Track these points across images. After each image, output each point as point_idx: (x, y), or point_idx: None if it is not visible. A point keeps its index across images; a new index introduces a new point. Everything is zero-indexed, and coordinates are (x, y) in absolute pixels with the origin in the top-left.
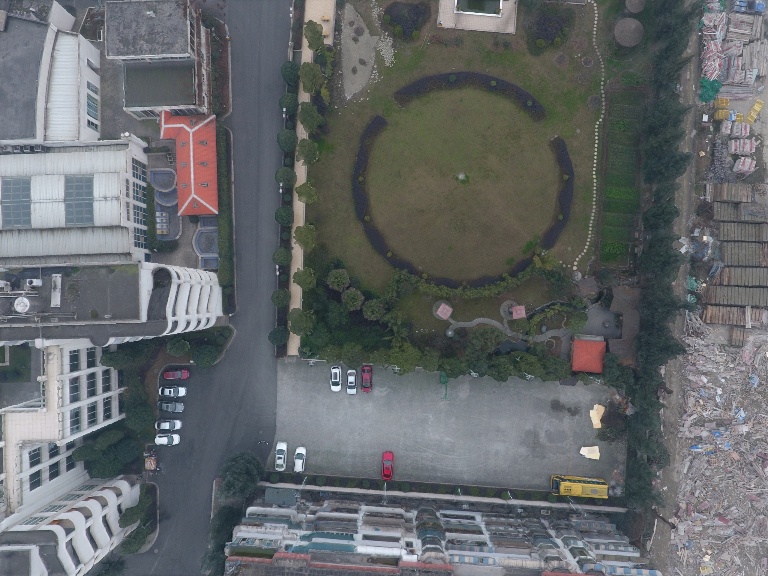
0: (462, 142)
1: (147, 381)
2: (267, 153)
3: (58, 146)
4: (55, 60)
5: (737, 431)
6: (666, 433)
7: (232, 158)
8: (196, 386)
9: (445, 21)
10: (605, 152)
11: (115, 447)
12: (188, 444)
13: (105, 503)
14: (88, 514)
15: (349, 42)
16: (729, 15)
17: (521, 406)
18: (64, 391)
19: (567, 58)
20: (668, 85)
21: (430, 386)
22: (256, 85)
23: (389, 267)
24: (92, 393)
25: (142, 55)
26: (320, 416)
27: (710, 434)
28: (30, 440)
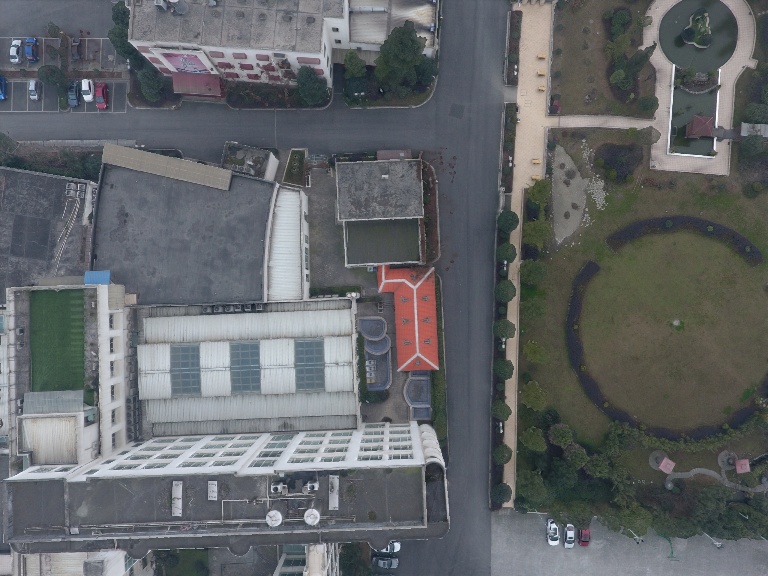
0: (676, 287)
1: None
2: (477, 299)
3: None
4: (276, 217)
5: None
6: None
7: (442, 305)
8: None
9: (657, 162)
10: None
11: None
12: None
13: None
14: None
15: (560, 185)
16: None
17: (740, 558)
18: None
19: None
20: None
21: (647, 538)
22: (465, 229)
23: (604, 416)
24: None
25: (375, 218)
26: (535, 569)
27: None
28: None
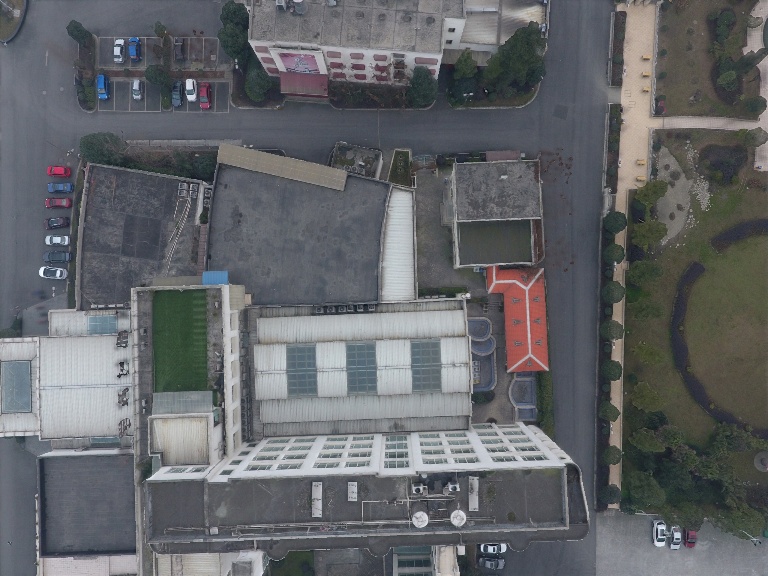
0: None
1: None
2: (582, 300)
3: None
4: (389, 217)
5: None
6: None
7: None
8: None
9: (761, 164)
10: None
11: None
12: None
13: None
14: None
15: None
16: None
17: None
18: None
19: None
20: None
21: None
22: (569, 230)
23: (709, 418)
24: None
25: (493, 219)
26: (640, 570)
27: None
28: None
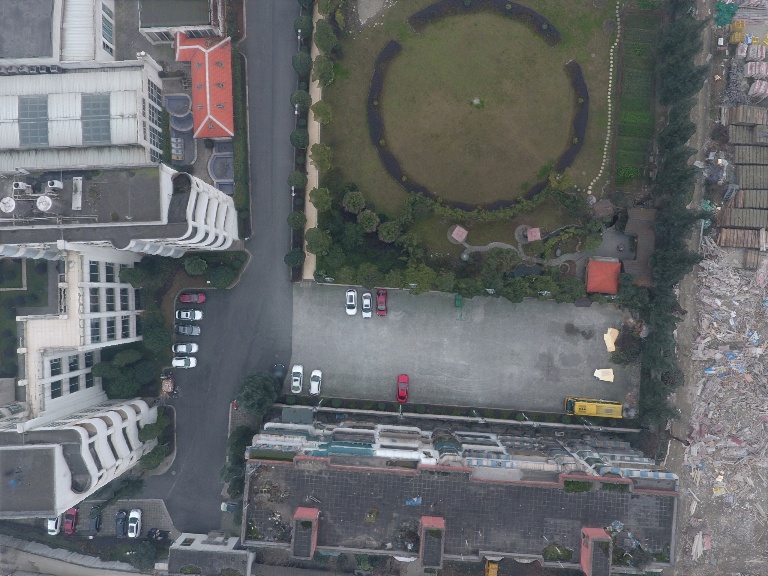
0: (477, 67)
1: (164, 305)
2: (281, 78)
3: (74, 68)
4: None
5: (751, 353)
6: (680, 356)
7: (247, 83)
8: (212, 310)
9: None
10: (620, 75)
11: (133, 367)
12: (205, 367)
13: (125, 416)
14: (109, 423)
15: None
16: None
17: (535, 330)
18: (85, 298)
19: None
20: (684, 4)
21: (445, 310)
22: (270, 10)
23: (404, 192)
24: (111, 308)
25: None
26: (335, 340)
27: (724, 356)
28: (52, 347)
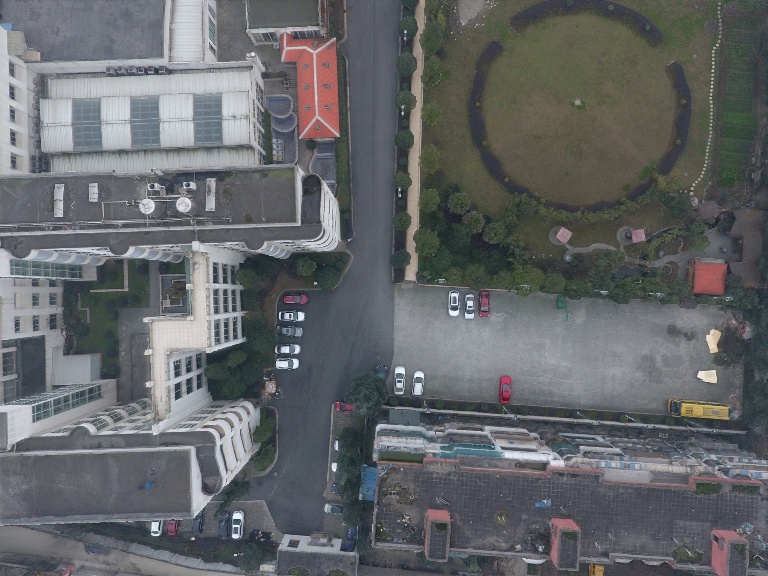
0: (578, 68)
1: (265, 306)
2: (383, 79)
3: (180, 69)
4: None
5: None
6: None
7: (347, 84)
8: (314, 311)
9: None
10: (723, 76)
11: (240, 368)
12: (306, 369)
13: (240, 418)
14: (231, 424)
15: None
16: None
17: (637, 331)
18: (210, 300)
19: None
20: None
21: (547, 311)
22: (371, 11)
23: (505, 193)
24: (226, 309)
25: None
26: (437, 341)
27: None
28: (177, 348)
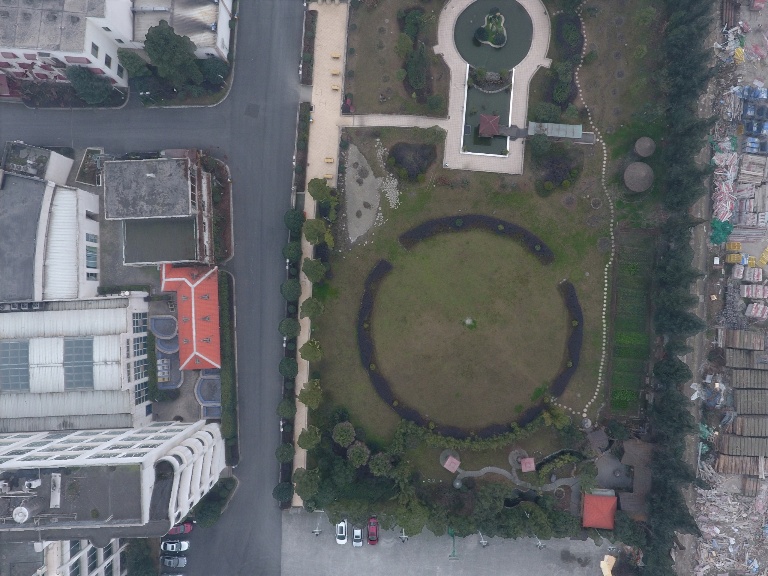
0: (469, 286)
1: None
2: (270, 298)
3: (57, 301)
4: (53, 215)
5: None
6: None
7: (234, 304)
8: (199, 538)
9: (451, 161)
10: (615, 297)
11: None
12: None
13: None
14: None
15: (353, 184)
16: (741, 156)
17: (530, 557)
18: None
19: (575, 199)
20: (679, 237)
21: (437, 537)
22: (258, 228)
23: (395, 415)
24: (93, 566)
25: (142, 217)
26: (325, 568)
27: None
28: None
